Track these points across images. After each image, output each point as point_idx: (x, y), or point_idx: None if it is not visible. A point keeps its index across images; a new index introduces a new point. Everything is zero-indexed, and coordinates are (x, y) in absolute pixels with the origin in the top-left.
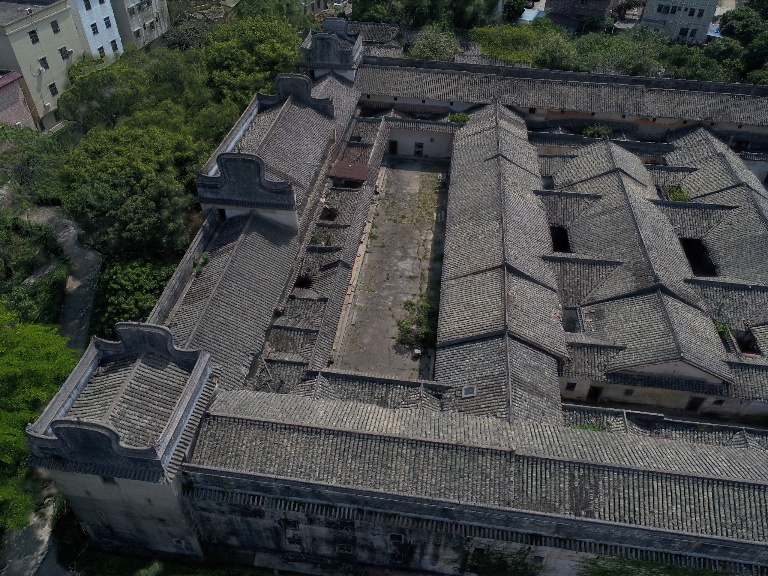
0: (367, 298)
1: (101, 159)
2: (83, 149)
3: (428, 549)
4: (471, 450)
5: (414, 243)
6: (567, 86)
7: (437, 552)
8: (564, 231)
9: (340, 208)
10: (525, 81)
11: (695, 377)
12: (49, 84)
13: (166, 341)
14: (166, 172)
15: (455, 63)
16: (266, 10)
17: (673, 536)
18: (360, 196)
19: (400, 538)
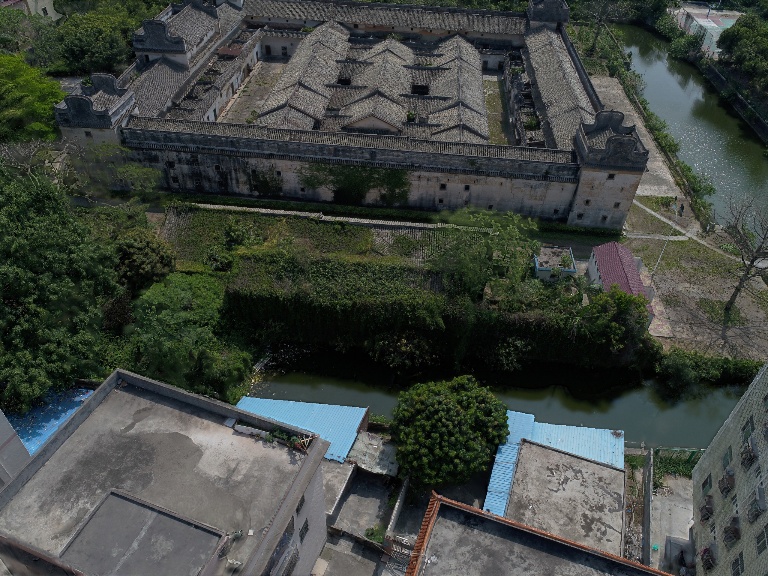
0: (234, 115)
1: None
2: (70, 23)
3: (233, 175)
4: (248, 126)
5: (268, 94)
6: (377, 10)
7: (237, 176)
8: (350, 81)
9: (221, 69)
10: (351, 7)
11: (384, 128)
12: (42, 8)
13: (113, 82)
14: None
15: None
16: None
17: (322, 146)
18: (232, 62)
19: (219, 168)
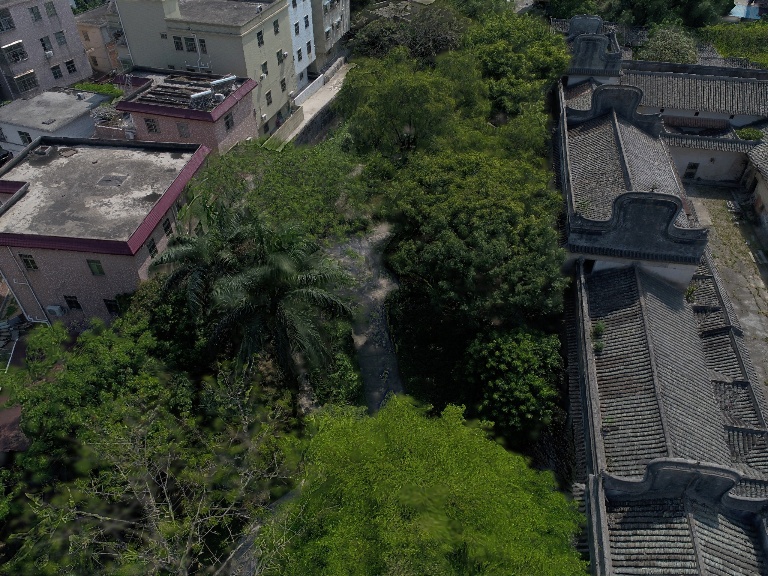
0: None
1: (448, 195)
2: (416, 181)
3: None
4: None
5: (746, 292)
6: None
7: None
8: None
9: None
10: None
11: None
12: (266, 92)
13: (730, 488)
14: (531, 213)
15: (728, 68)
16: (477, 7)
17: None
18: None
19: None
